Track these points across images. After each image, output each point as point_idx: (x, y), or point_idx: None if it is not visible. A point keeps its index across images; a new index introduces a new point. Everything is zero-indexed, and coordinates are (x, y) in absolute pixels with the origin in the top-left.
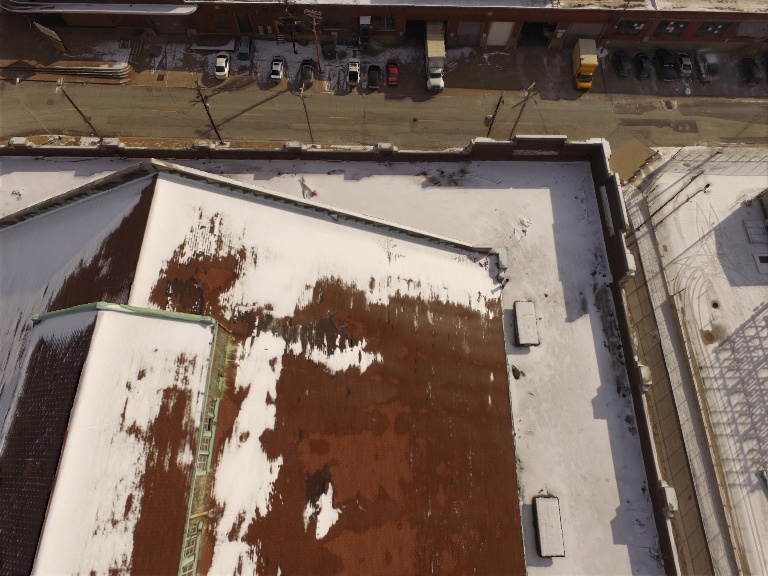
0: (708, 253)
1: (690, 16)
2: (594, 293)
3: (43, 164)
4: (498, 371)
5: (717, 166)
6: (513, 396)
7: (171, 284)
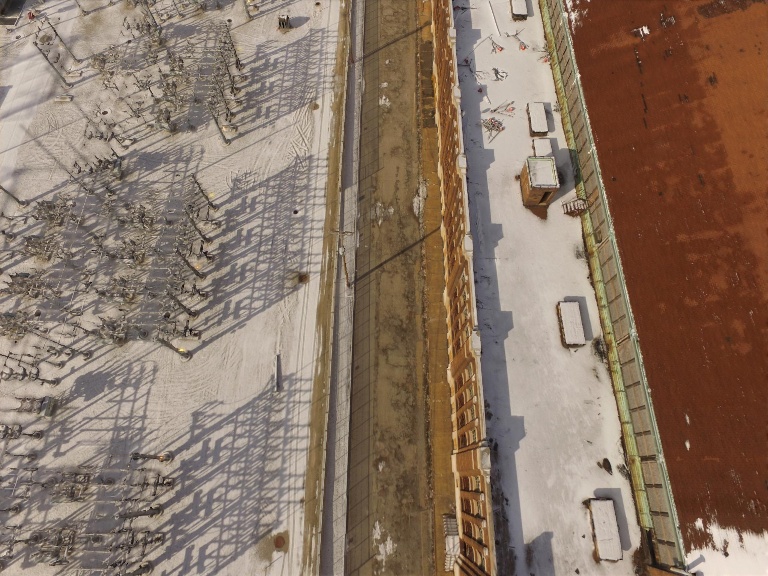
0: None
1: None
2: (516, 575)
3: None
4: (679, 453)
5: None
6: (609, 440)
7: None
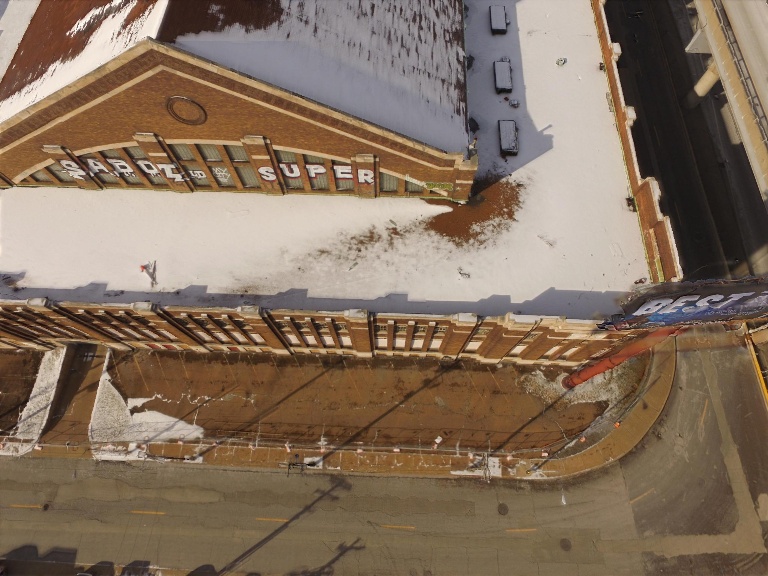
0: None
1: None
2: None
3: (447, 311)
4: None
5: None
6: None
7: None
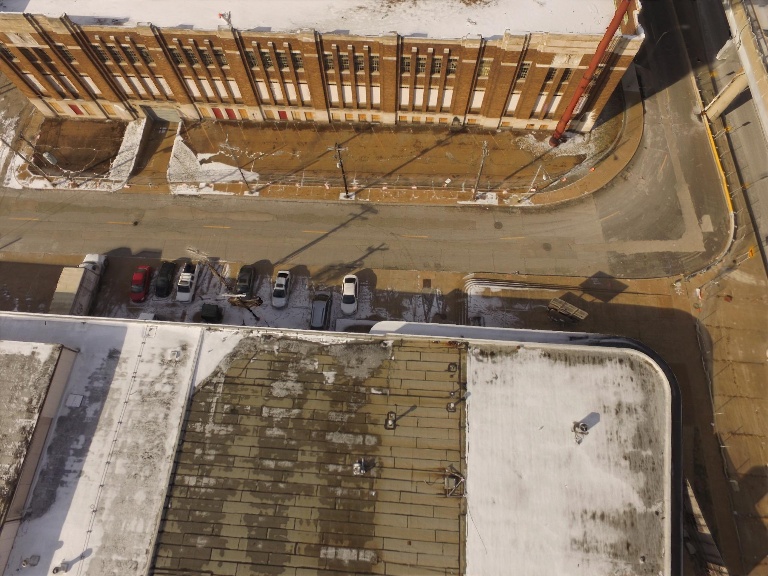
0: None
1: None
2: None
3: None
4: None
5: None
6: None
7: None
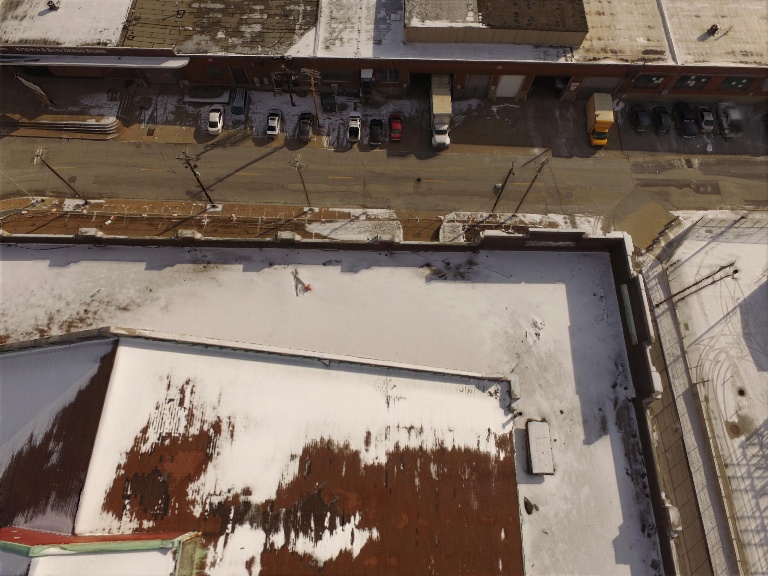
0: (733, 333)
1: (713, 71)
2: (615, 409)
3: (16, 252)
4: (510, 525)
5: (741, 233)
6: (525, 535)
7: (130, 482)
